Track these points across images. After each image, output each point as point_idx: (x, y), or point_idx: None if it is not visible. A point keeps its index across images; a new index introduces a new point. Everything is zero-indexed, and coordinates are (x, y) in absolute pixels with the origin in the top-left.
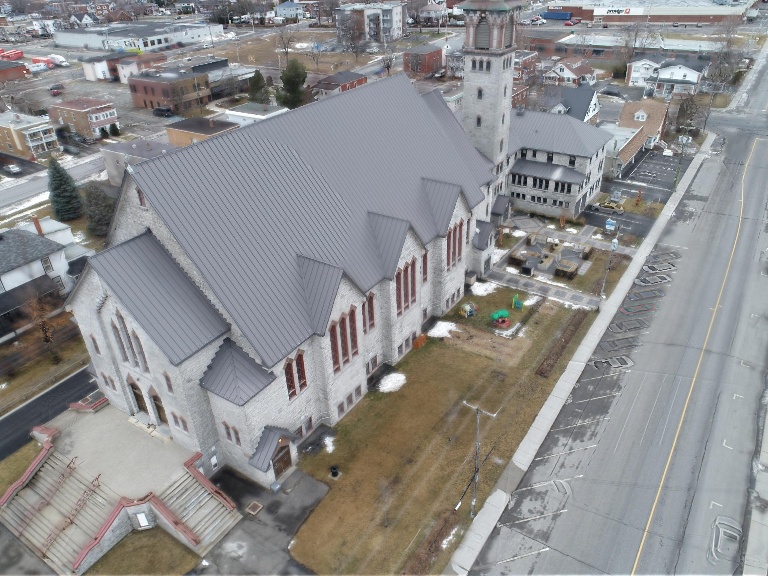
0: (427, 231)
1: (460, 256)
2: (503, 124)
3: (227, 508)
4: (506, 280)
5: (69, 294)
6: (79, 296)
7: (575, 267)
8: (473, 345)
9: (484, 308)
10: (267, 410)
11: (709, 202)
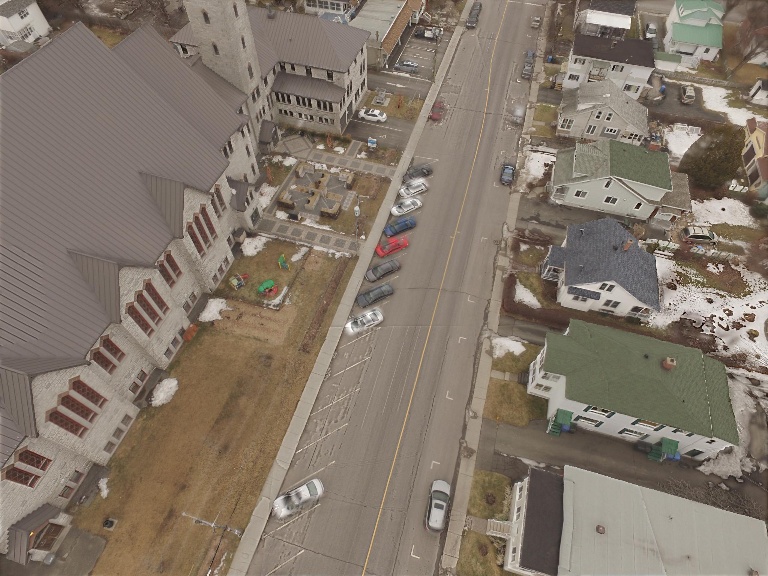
0: (159, 238)
1: (215, 233)
2: (245, 48)
3: None
4: (275, 230)
5: None
6: None
7: (338, 206)
8: (242, 326)
9: (254, 272)
10: (1, 519)
11: (461, 94)
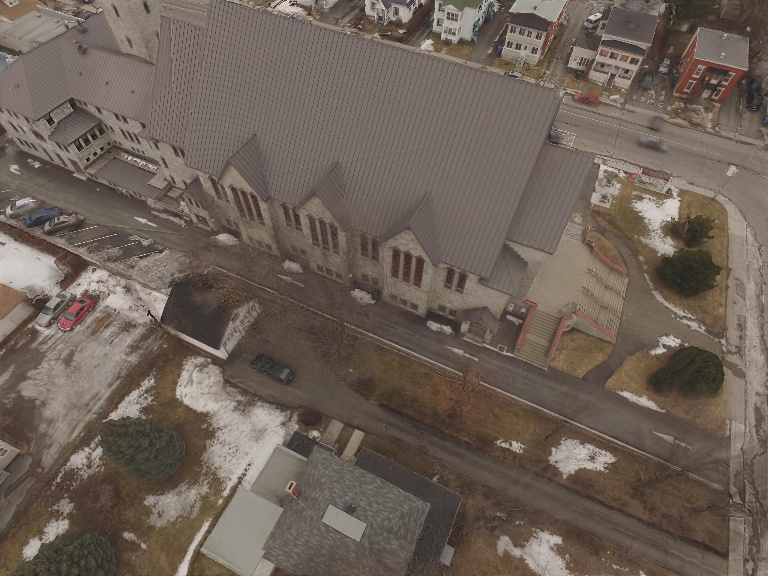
0: None
1: None
2: None
3: None
4: None
5: None
6: None
7: None
8: None
9: None
10: None
11: None
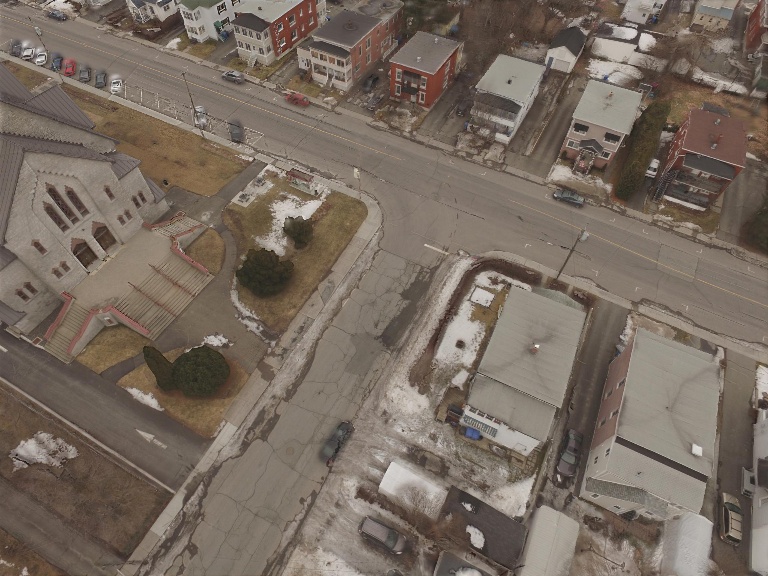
0: None
1: None
2: None
3: (181, 219)
4: None
5: (8, 214)
6: (12, 211)
7: None
8: None
9: None
10: None
11: None
